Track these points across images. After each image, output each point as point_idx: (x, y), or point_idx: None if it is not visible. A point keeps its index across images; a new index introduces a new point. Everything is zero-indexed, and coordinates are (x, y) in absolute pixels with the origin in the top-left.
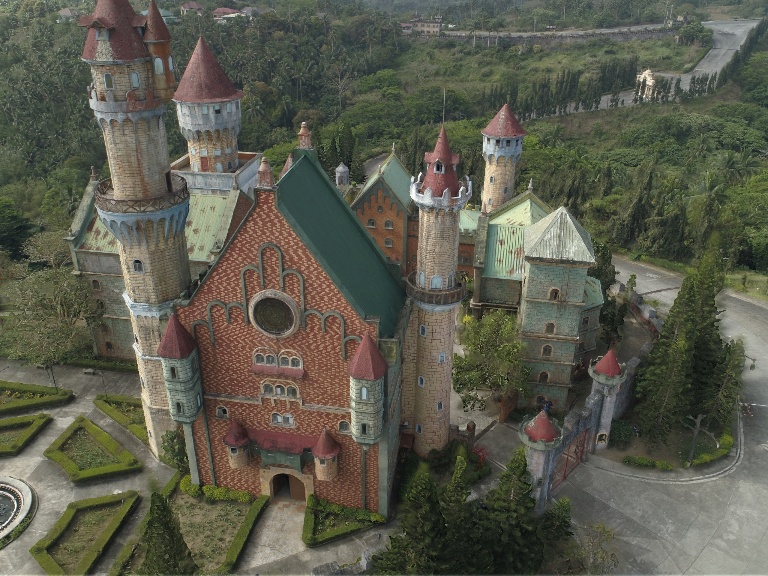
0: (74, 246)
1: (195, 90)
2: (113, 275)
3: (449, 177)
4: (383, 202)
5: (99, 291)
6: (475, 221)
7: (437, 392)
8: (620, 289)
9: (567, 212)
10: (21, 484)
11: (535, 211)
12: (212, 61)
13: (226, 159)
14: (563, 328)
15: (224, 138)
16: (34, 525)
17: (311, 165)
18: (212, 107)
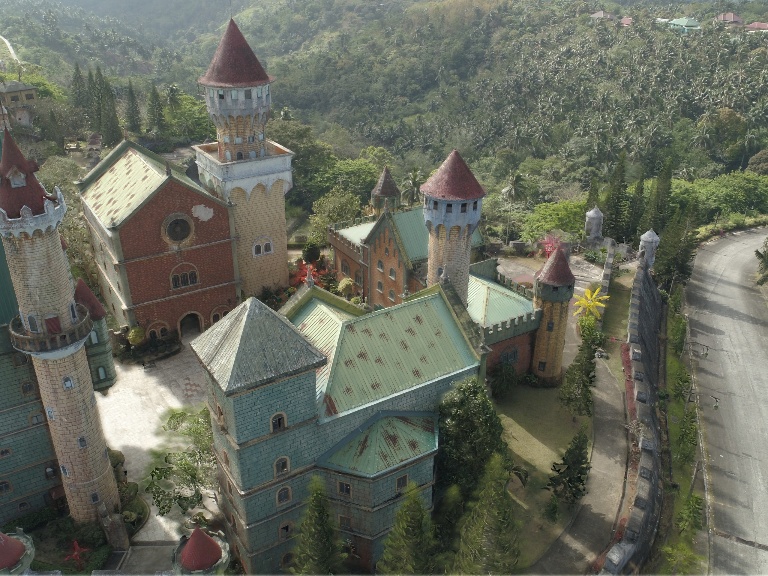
0: (80, 190)
1: (210, 71)
2: (91, 225)
3: (4, 192)
4: (389, 244)
5: (91, 236)
6: (489, 309)
7: (58, 451)
8: (636, 502)
9: (258, 307)
10: None
11: (415, 310)
12: (234, 44)
13: (236, 148)
14: (233, 468)
15: (233, 126)
16: None
17: (1, 148)
18: (217, 91)
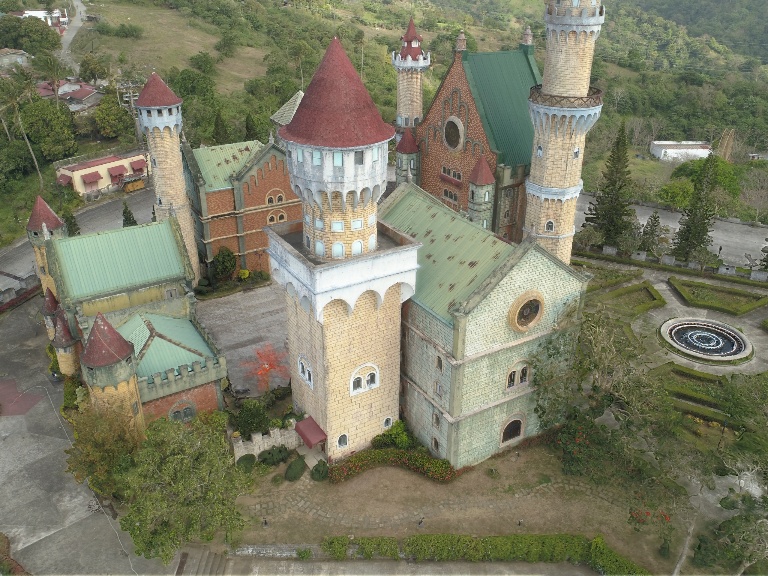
0: None
1: None
2: None
3: None
4: None
5: None
6: None
7: None
8: None
9: None
10: (668, 339)
11: None
12: None
13: None
14: None
15: None
16: (662, 322)
17: None
18: None
